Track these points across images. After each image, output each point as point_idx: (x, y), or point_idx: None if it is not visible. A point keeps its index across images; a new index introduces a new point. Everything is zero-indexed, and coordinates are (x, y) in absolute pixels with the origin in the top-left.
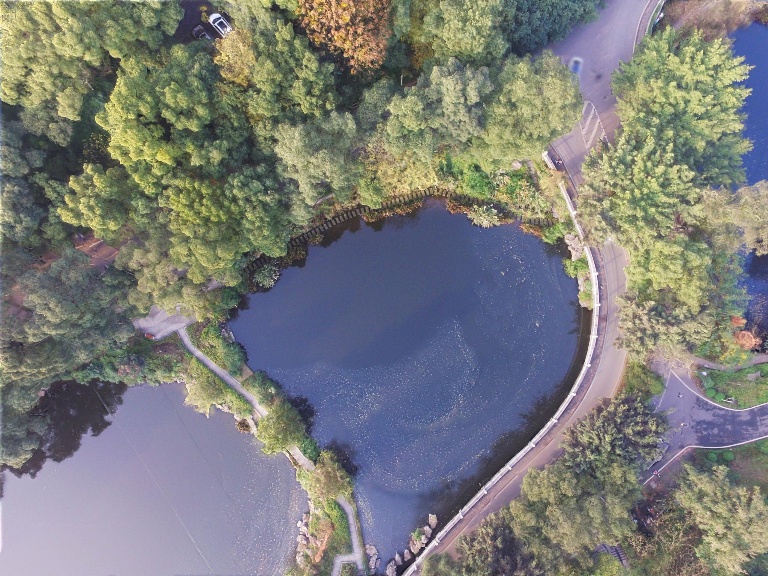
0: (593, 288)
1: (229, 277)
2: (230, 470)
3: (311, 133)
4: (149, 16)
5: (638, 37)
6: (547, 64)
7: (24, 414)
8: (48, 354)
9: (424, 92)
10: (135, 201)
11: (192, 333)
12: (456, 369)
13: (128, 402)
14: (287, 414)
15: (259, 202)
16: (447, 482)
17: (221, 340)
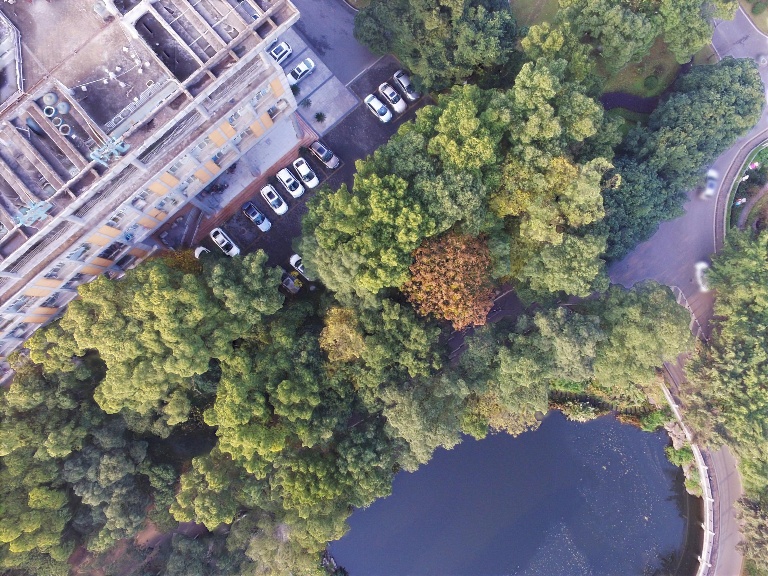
0: (702, 479)
1: None
2: None
3: (425, 405)
4: (255, 317)
5: (717, 215)
6: (654, 298)
7: None
8: None
9: (532, 342)
10: (247, 489)
11: None
12: (568, 574)
13: None
14: None
15: (371, 468)
16: None
17: (324, 572)
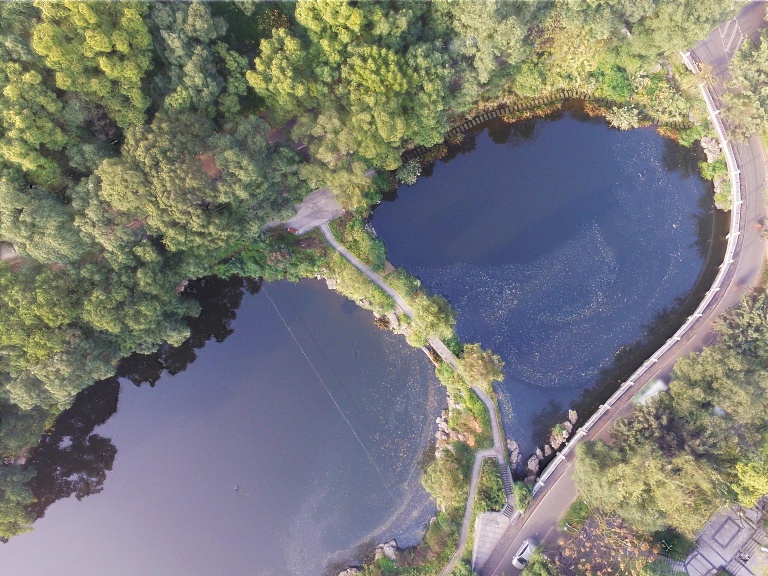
0: (732, 188)
1: (393, 158)
2: (369, 366)
3: (497, 2)
4: None
5: None
6: None
7: (179, 297)
8: (227, 221)
9: None
10: (320, 68)
11: (336, 227)
12: (595, 268)
13: (246, 314)
14: (442, 299)
15: (436, 76)
16: (587, 378)
17: (366, 234)
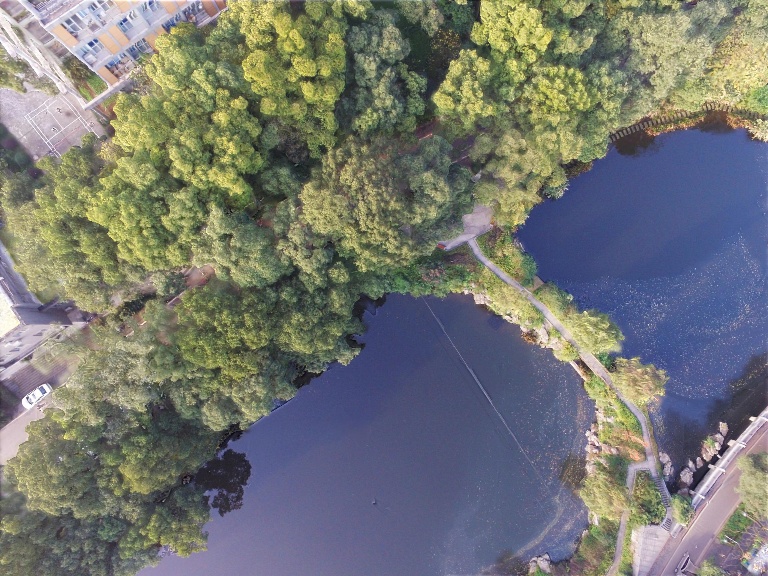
0: None
1: (559, 175)
2: (517, 380)
3: None
4: None
5: None
6: None
7: None
8: None
9: None
10: (506, 88)
11: (484, 243)
12: (742, 280)
13: (371, 327)
14: (605, 314)
15: None
16: (737, 390)
17: (516, 249)
